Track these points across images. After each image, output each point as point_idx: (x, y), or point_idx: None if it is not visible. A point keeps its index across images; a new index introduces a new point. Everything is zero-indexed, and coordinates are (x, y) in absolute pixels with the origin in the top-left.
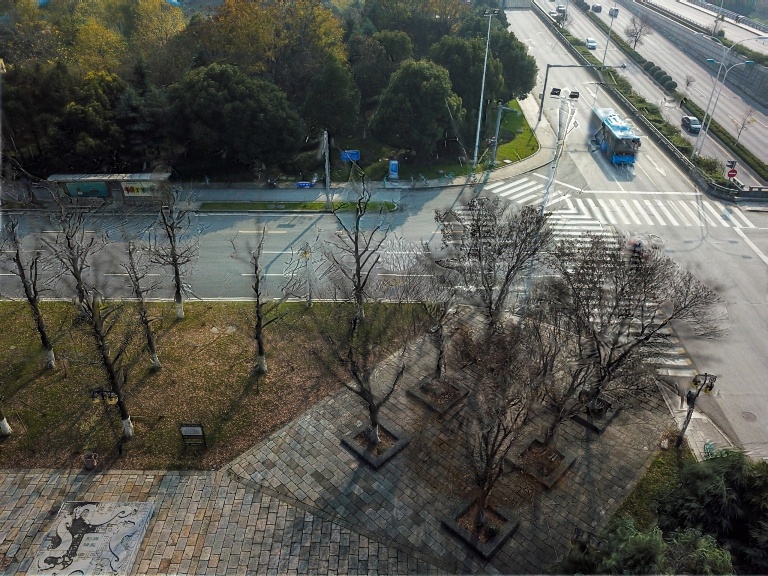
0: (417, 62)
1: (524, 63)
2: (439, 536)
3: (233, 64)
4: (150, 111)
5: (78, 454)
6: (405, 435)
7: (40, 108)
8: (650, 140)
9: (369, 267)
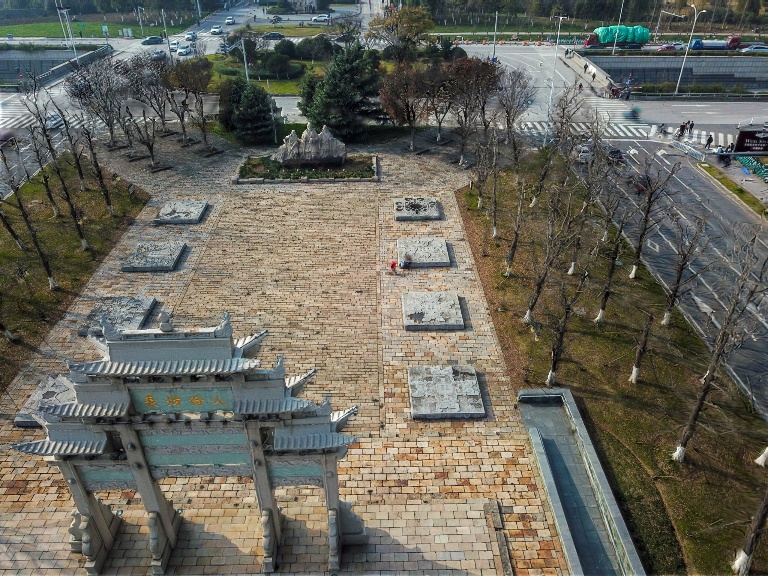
0: None
1: None
2: None
3: None
4: None
5: (118, 228)
6: None
7: None
8: None
9: None
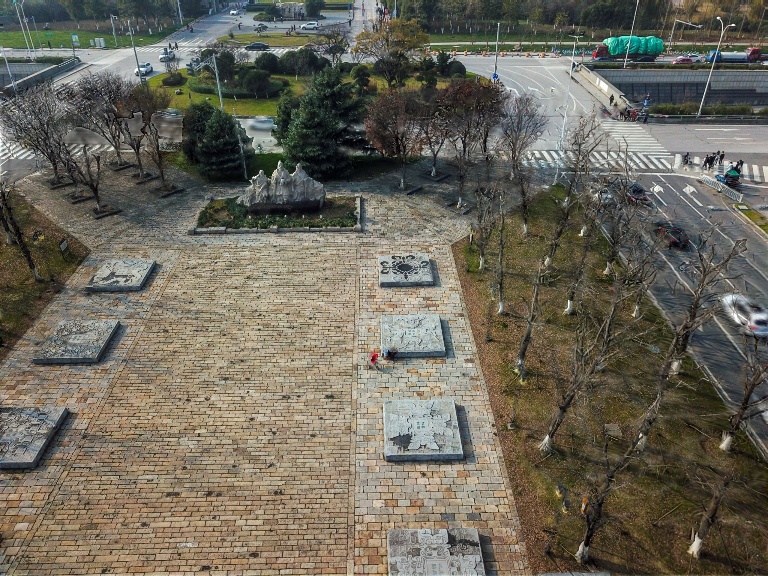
0: None
1: None
2: (168, 198)
3: None
4: None
5: (41, 297)
6: None
7: None
8: None
9: None
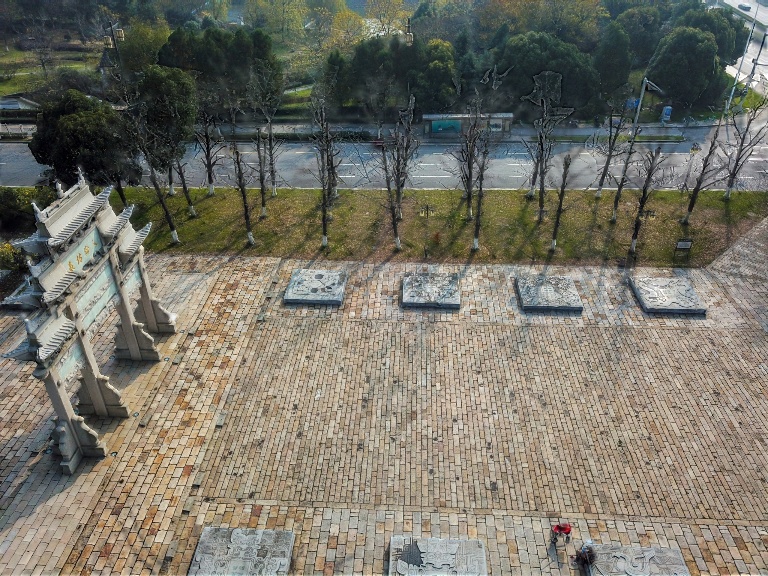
0: (689, 28)
1: (740, 34)
2: None
3: (546, 32)
4: (483, 68)
5: (608, 260)
6: None
7: (406, 66)
8: None
9: (744, 159)
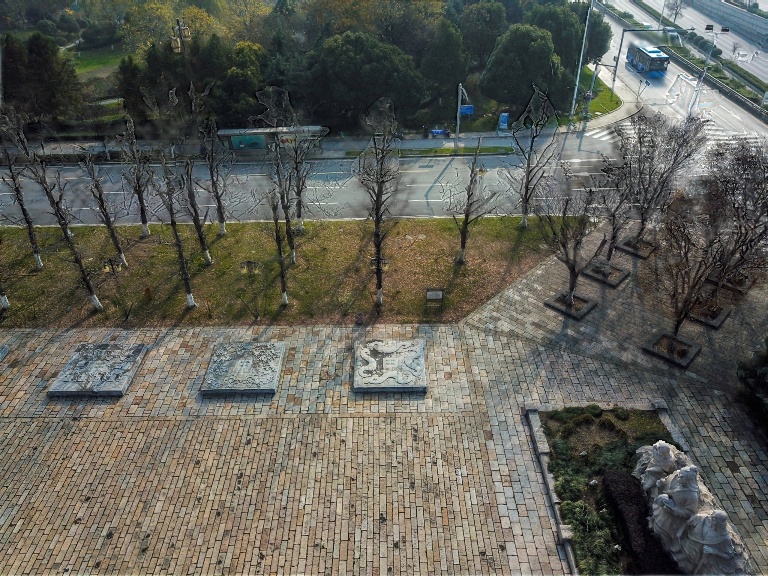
0: (523, 26)
1: (600, 29)
2: (644, 357)
3: (364, 32)
4: (294, 75)
5: (346, 315)
6: (592, 299)
7: (203, 74)
8: (719, 94)
9: (535, 181)
